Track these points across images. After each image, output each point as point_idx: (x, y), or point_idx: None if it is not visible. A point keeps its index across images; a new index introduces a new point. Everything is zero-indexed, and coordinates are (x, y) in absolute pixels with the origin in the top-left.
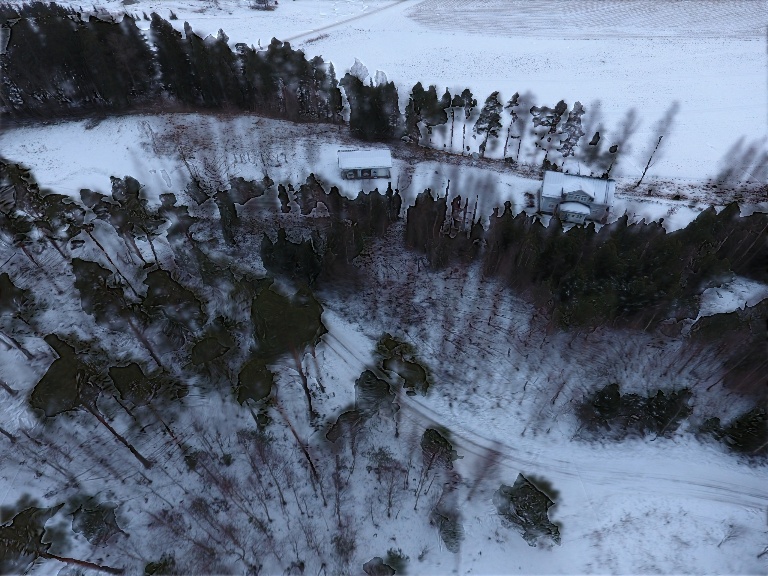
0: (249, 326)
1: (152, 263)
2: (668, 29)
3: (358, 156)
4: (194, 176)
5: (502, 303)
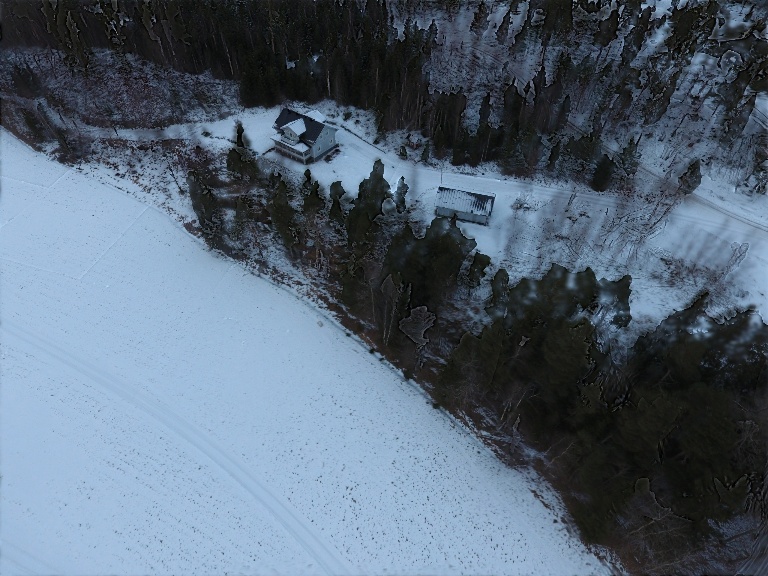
0: None
1: (616, 1)
2: None
3: None
4: None
5: (432, 83)
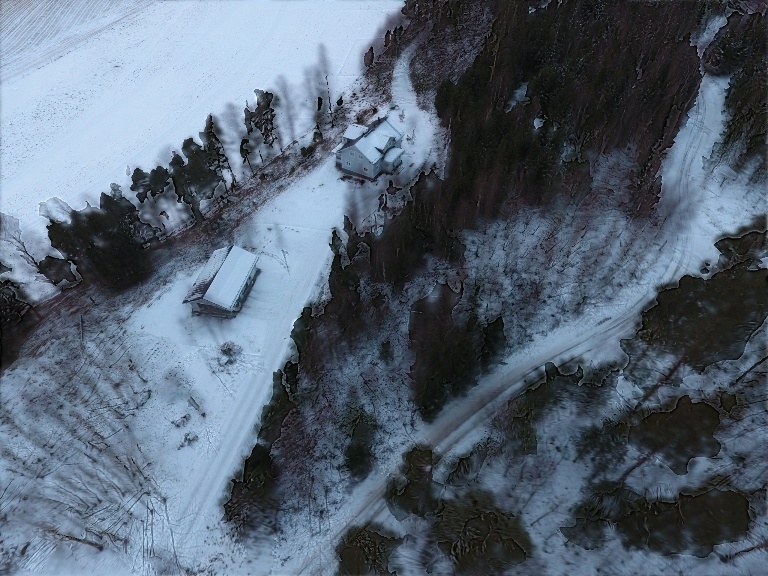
0: (685, 362)
1: None
2: (107, 14)
3: (223, 280)
4: (99, 543)
5: (518, 227)
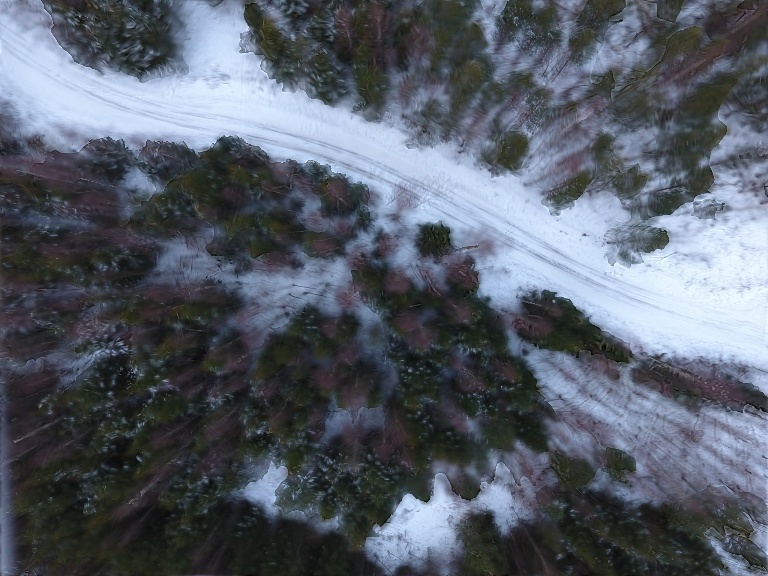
0: None
1: None
2: None
3: None
4: None
5: (729, 554)
